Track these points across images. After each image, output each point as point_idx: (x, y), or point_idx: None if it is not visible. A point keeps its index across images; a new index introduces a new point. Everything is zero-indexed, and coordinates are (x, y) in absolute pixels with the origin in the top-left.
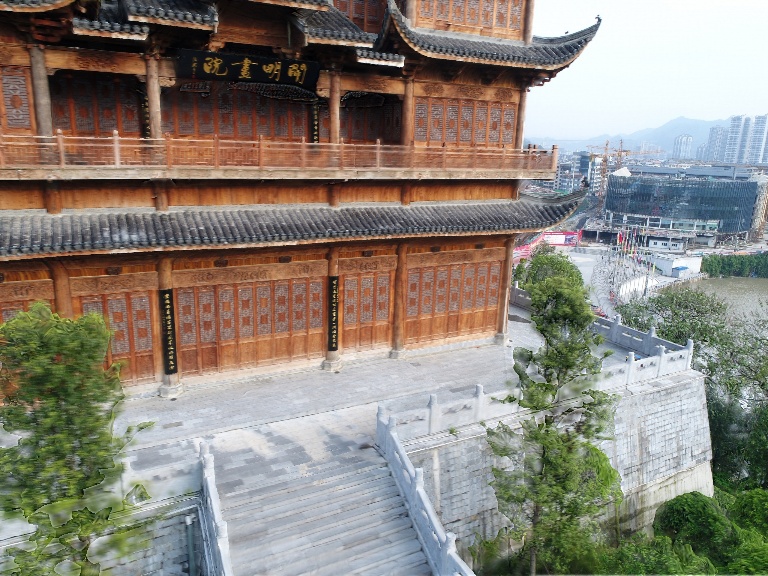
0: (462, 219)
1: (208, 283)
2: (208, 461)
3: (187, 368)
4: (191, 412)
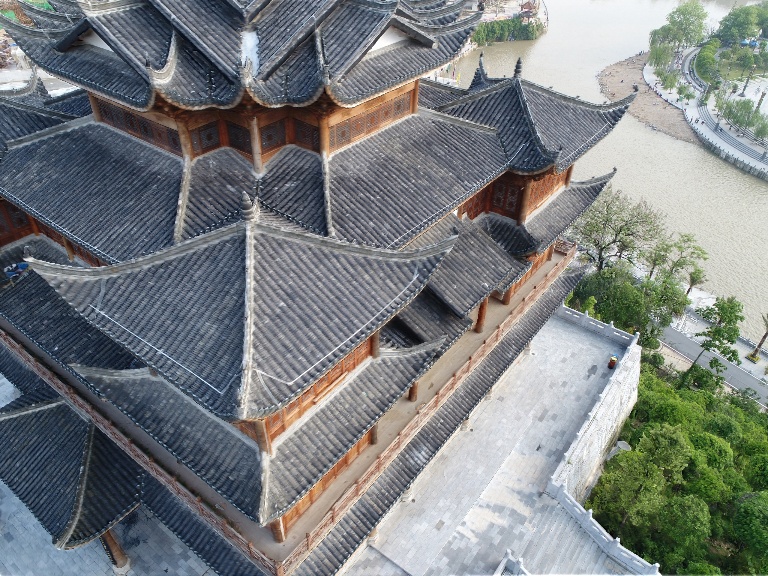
0: (534, 316)
1: None
2: None
3: None
4: (436, 509)
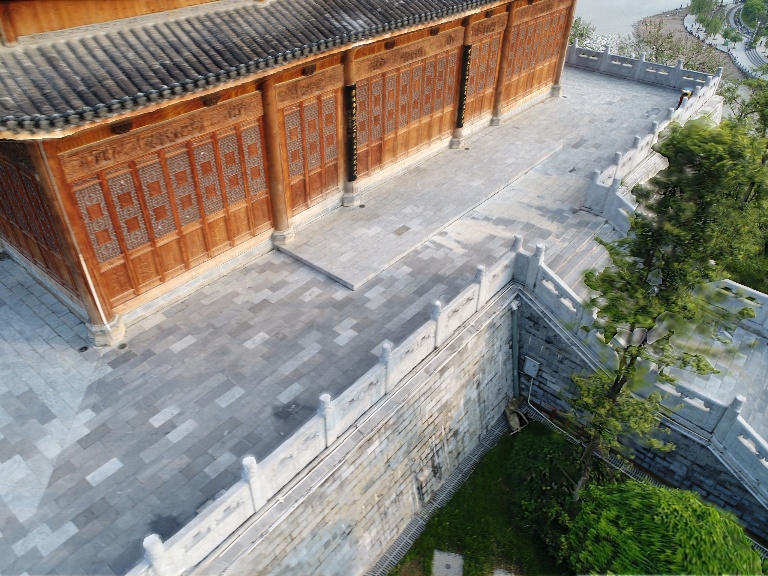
0: None
1: (381, 70)
2: (543, 250)
3: (360, 171)
4: (399, 214)
